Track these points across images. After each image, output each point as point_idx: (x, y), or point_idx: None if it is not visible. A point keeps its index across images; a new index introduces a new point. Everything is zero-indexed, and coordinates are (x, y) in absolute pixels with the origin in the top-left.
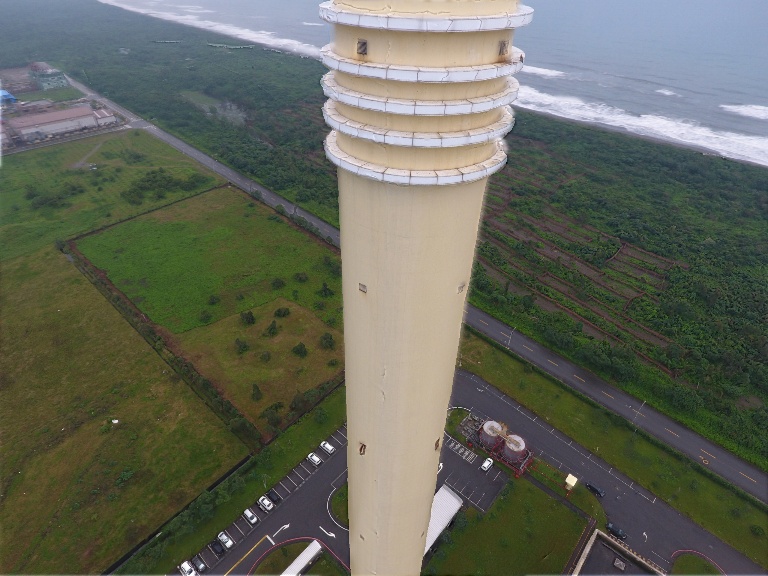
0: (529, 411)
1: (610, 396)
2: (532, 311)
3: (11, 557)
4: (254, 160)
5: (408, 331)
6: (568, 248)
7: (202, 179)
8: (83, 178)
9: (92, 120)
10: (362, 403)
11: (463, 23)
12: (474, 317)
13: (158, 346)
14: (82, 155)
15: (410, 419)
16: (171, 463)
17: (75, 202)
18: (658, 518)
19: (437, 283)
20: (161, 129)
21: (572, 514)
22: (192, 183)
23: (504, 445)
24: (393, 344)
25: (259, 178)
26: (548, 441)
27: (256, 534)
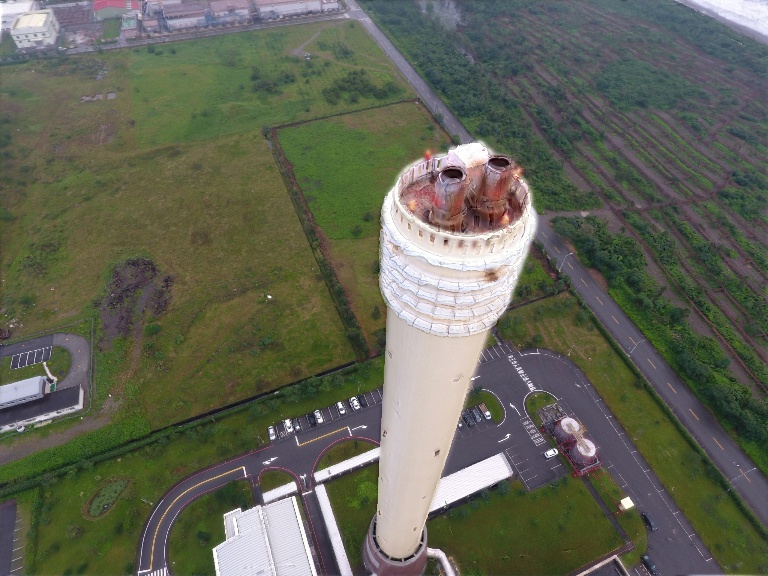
0: (619, 424)
1: (720, 446)
2: (677, 327)
3: (188, 367)
4: (449, 77)
5: (413, 391)
6: (767, 268)
7: (395, 89)
8: (297, 67)
9: (318, 4)
10: (387, 409)
11: (450, 266)
12: (608, 311)
13: (314, 245)
14: (302, 42)
15: (413, 435)
16: (298, 344)
17: (285, 91)
18: (703, 575)
19: (436, 373)
20: (374, 24)
21: (613, 530)
22: (385, 92)
23: (575, 444)
24: (404, 392)
25: (448, 99)
26: (624, 459)
27: (341, 422)
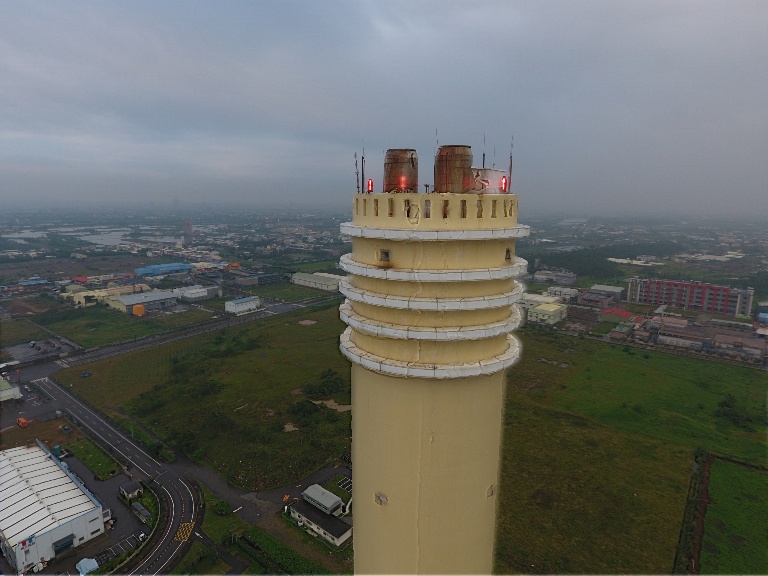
0: None
1: None
2: None
3: None
4: None
5: None
6: None
7: None
8: None
9: None
10: None
11: (347, 229)
12: None
13: None
14: None
15: None
16: None
17: (760, 431)
18: None
19: None
20: None
21: None
22: None
23: None
24: None
25: None
26: None
27: None
